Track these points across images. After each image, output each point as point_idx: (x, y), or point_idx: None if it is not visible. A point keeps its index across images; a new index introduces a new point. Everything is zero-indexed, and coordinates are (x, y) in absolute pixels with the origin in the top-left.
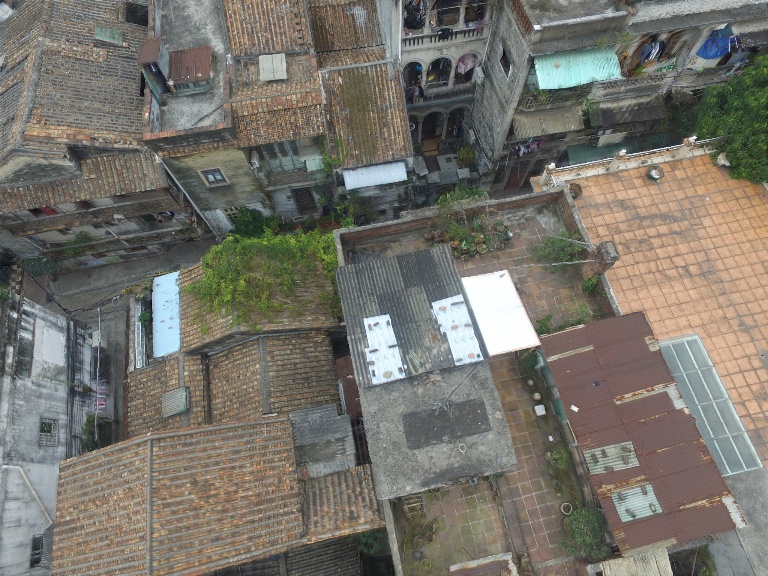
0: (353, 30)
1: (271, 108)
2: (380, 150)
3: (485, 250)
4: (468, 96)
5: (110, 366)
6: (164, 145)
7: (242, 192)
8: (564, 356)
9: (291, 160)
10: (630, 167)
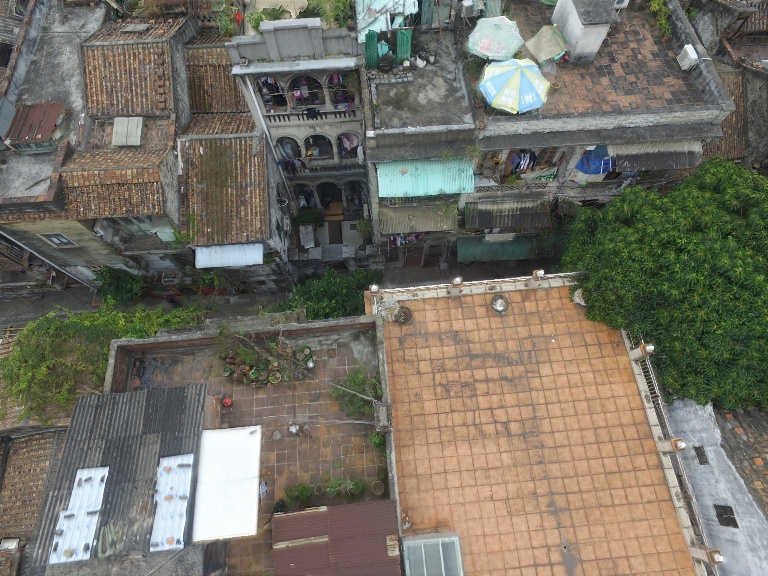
0: (233, 93)
1: (104, 181)
2: (234, 230)
3: (277, 380)
4: (360, 170)
5: None
6: None
7: (98, 254)
8: (293, 544)
9: (151, 226)
10: (475, 292)
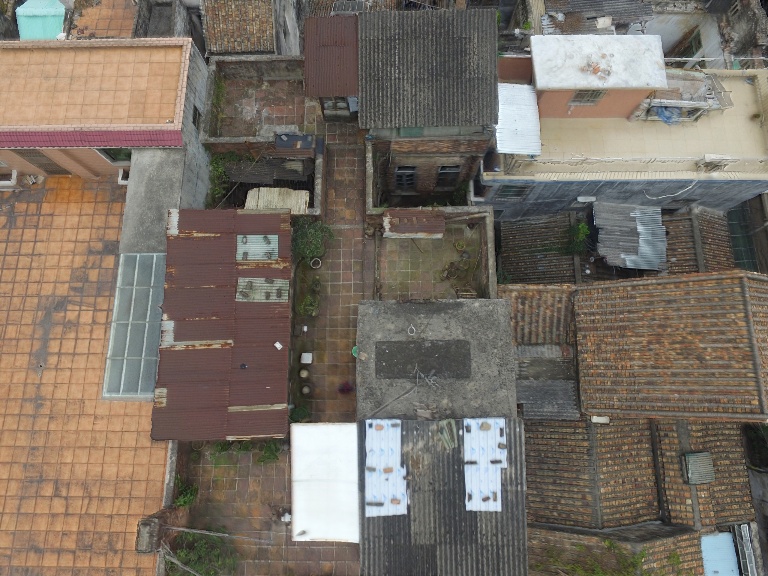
0: None
1: None
2: None
3: None
4: None
5: (767, 539)
6: None
7: None
8: (265, 406)
9: None
10: None
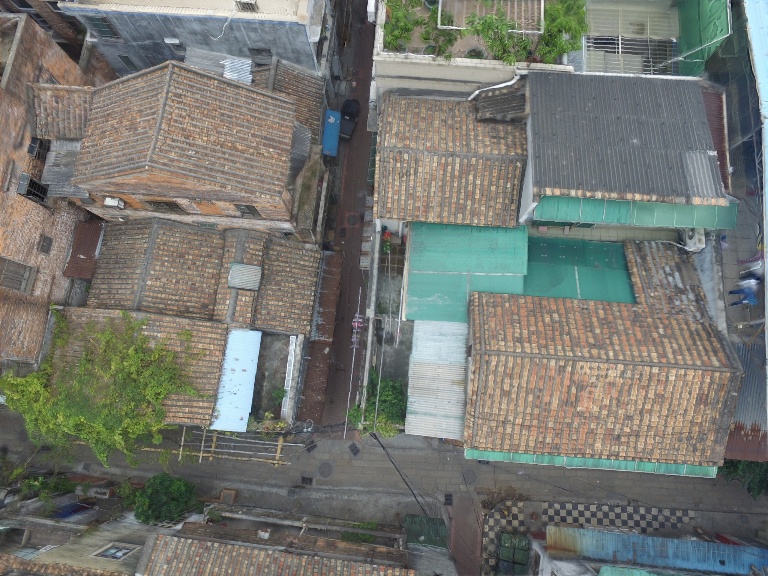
0: None
1: None
2: None
3: None
4: None
5: None
6: None
7: None
8: None
9: None
10: None
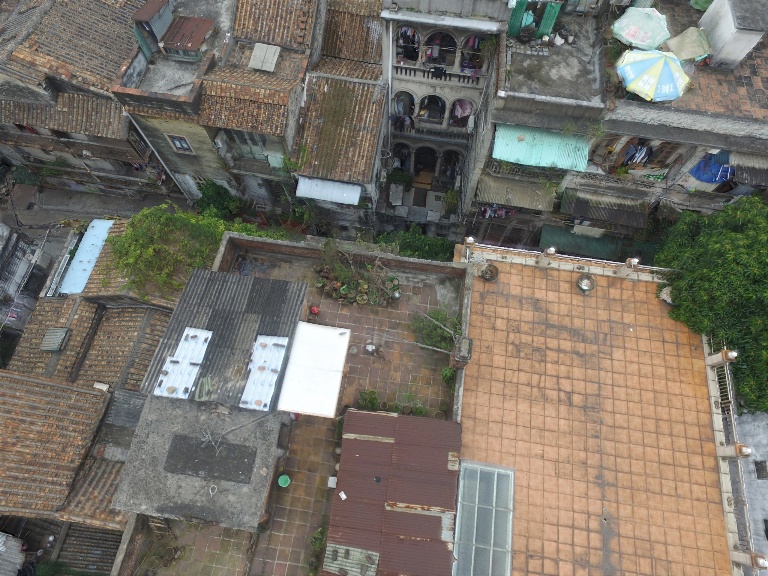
0: (364, 43)
1: (238, 95)
2: (339, 168)
3: (364, 301)
4: (463, 141)
5: None
6: (130, 100)
7: (208, 166)
8: (361, 438)
9: (261, 150)
10: (563, 268)
